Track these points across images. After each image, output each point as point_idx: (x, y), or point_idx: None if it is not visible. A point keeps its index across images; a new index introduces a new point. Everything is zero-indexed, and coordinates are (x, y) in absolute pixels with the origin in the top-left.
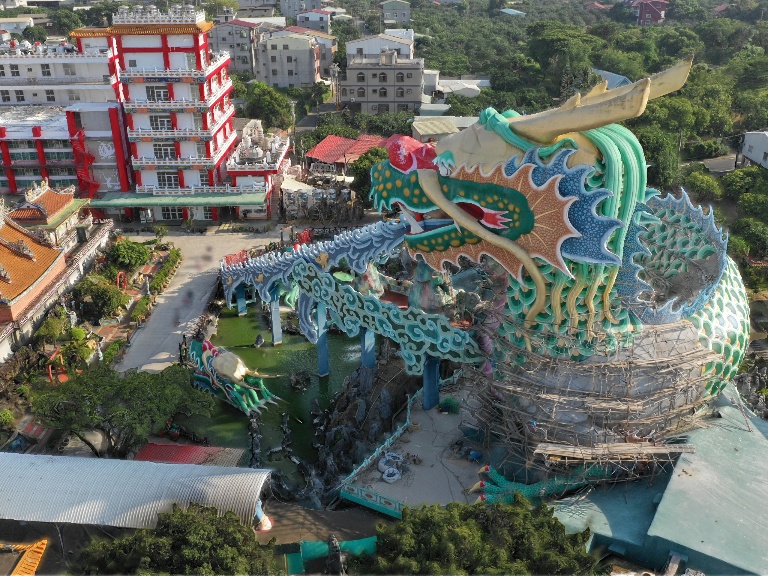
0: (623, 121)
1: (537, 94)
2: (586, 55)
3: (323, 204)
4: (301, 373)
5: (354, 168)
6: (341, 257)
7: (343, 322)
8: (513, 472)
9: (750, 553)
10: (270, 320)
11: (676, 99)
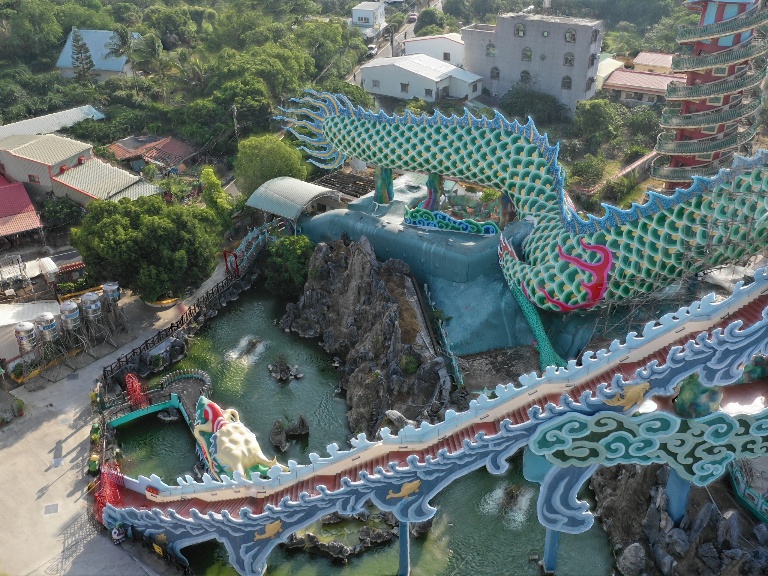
0: (264, 82)
1: (43, 75)
2: (52, 14)
3: None
4: None
5: (112, 246)
6: (686, 376)
7: (690, 471)
8: None
9: None
10: (339, 548)
11: (269, 46)
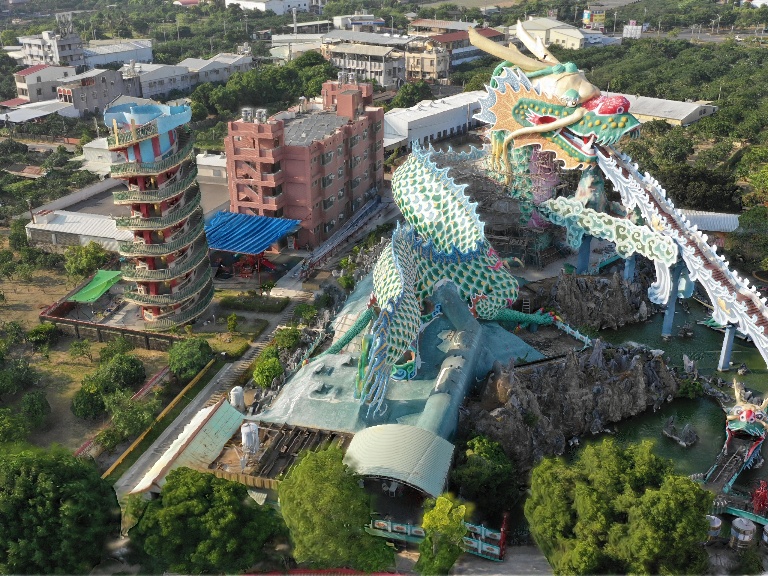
0: None
1: None
2: None
3: (759, 551)
4: (686, 328)
5: None
6: None
7: None
8: None
9: None
10: None
11: None
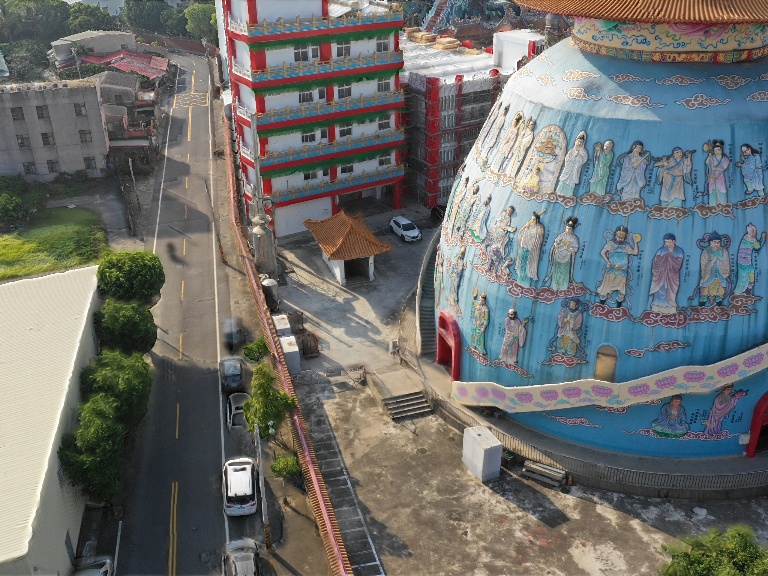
0: None
1: None
2: None
3: None
4: None
5: None
6: None
7: None
8: (485, 10)
9: None
10: None
11: None
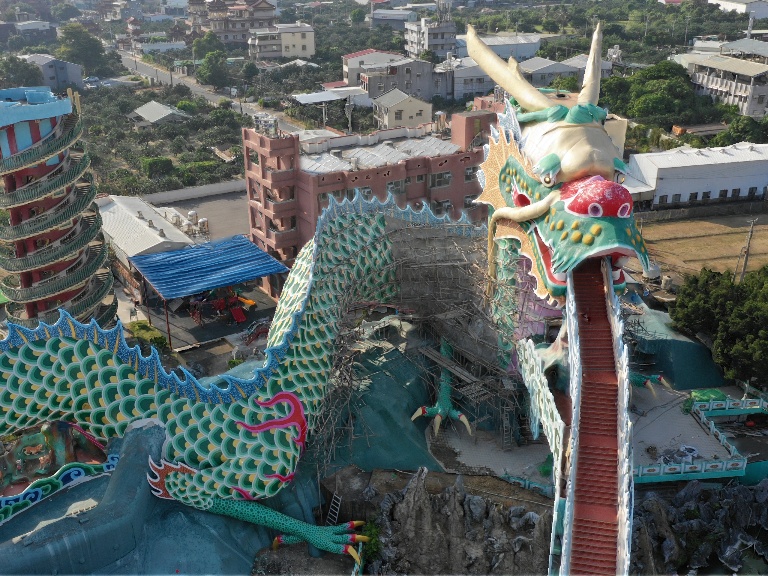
0: None
1: None
2: None
3: None
4: None
5: None
6: None
7: None
8: None
9: None
10: None
11: None
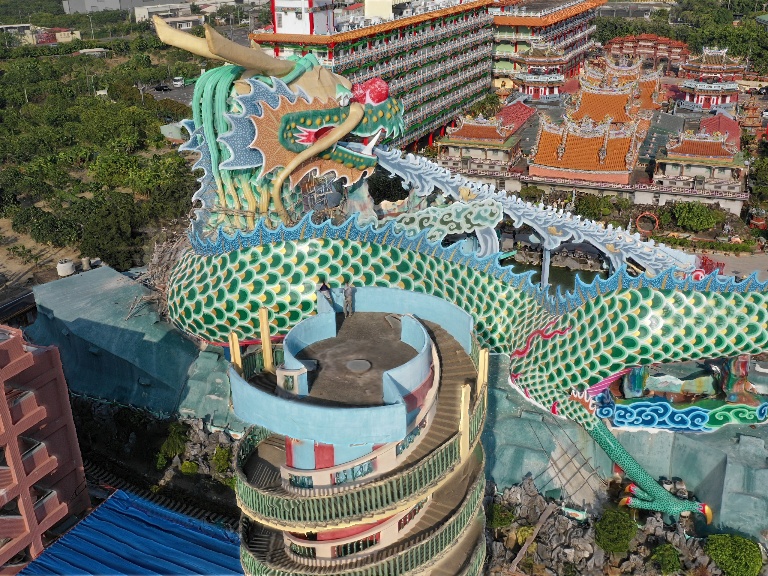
0: None
1: None
2: None
3: None
4: None
5: None
6: None
7: None
8: None
9: (58, 284)
10: None
11: None
